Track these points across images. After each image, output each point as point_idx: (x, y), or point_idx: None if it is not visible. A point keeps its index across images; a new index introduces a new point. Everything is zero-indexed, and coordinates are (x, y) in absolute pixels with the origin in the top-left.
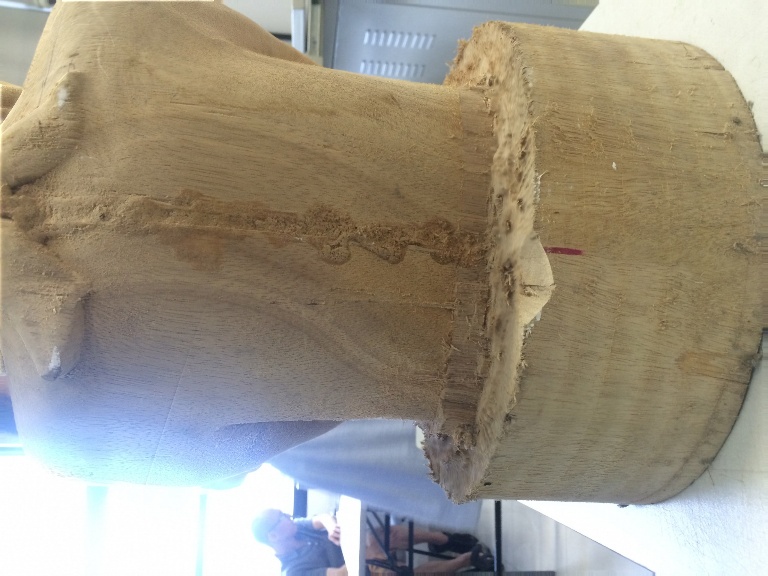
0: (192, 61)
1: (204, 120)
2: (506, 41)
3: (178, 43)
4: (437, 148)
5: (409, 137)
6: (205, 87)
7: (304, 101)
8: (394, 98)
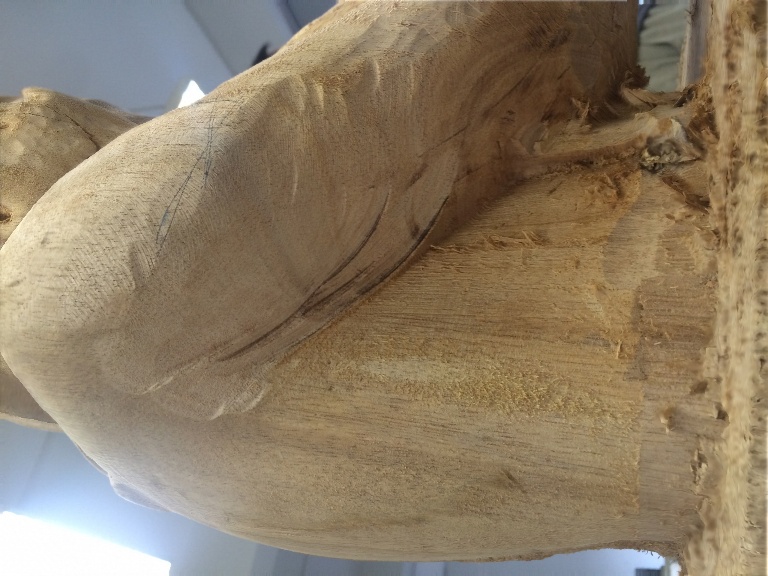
0: (214, 476)
1: (275, 538)
2: (745, 482)
3: (180, 451)
4: (591, 526)
5: (543, 523)
6: (251, 512)
7: (376, 513)
8: (512, 477)
